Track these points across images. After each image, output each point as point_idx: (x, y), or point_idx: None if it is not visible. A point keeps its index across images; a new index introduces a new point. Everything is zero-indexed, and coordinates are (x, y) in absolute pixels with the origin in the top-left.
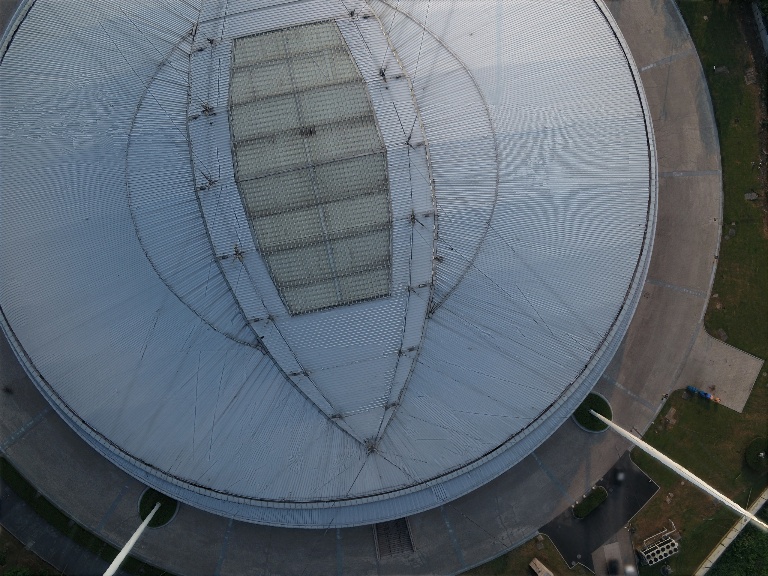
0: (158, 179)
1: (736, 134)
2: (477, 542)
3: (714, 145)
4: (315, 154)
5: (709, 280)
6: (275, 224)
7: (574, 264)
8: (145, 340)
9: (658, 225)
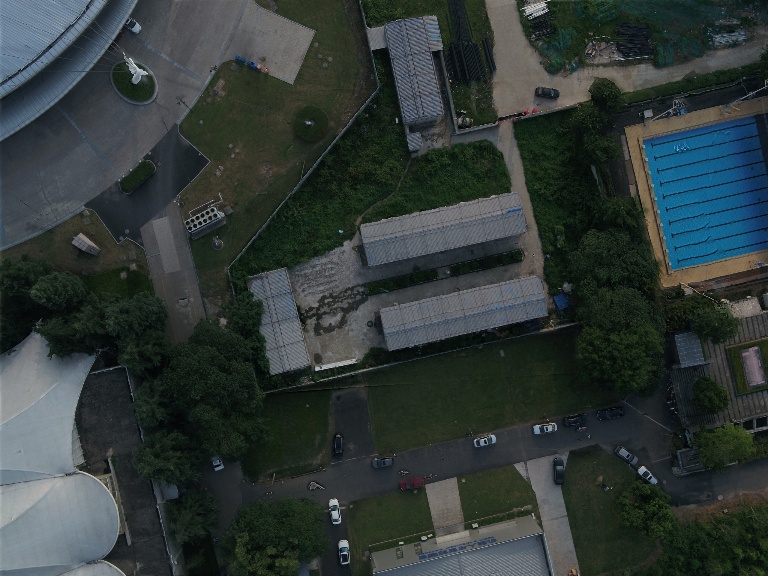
0: None
1: None
2: (20, 218)
3: None
4: None
5: None
6: None
7: None
8: None
9: None
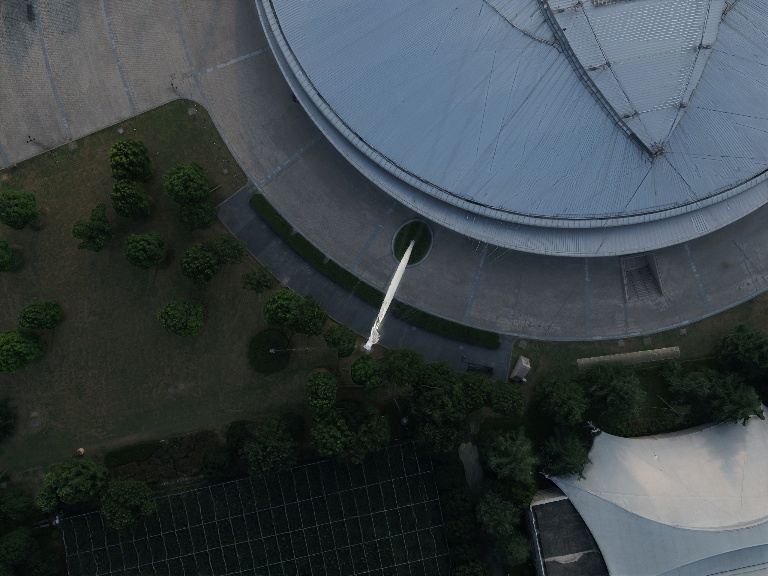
0: None
1: None
2: (723, 287)
3: None
4: None
5: None
6: None
7: None
8: (440, 41)
9: None
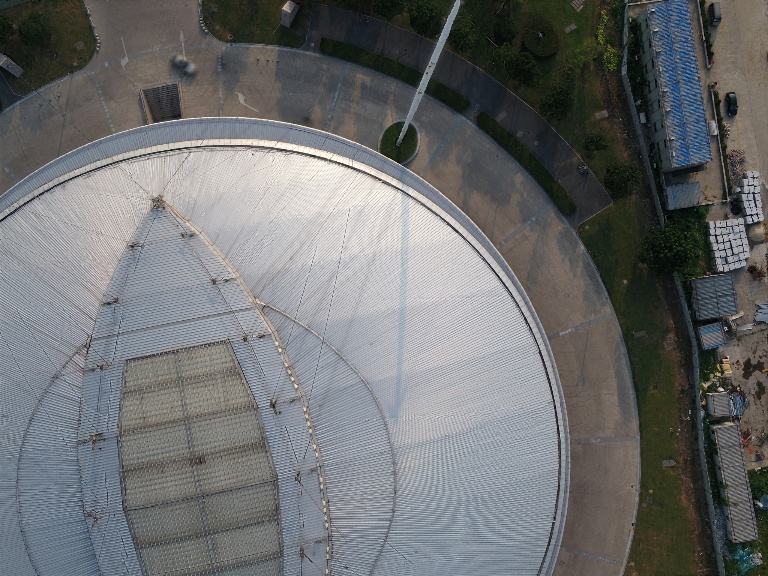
0: (48, 496)
1: (655, 400)
2: None
3: (632, 411)
4: (204, 484)
5: (625, 548)
6: (163, 554)
7: (476, 568)
8: None
9: (574, 492)
